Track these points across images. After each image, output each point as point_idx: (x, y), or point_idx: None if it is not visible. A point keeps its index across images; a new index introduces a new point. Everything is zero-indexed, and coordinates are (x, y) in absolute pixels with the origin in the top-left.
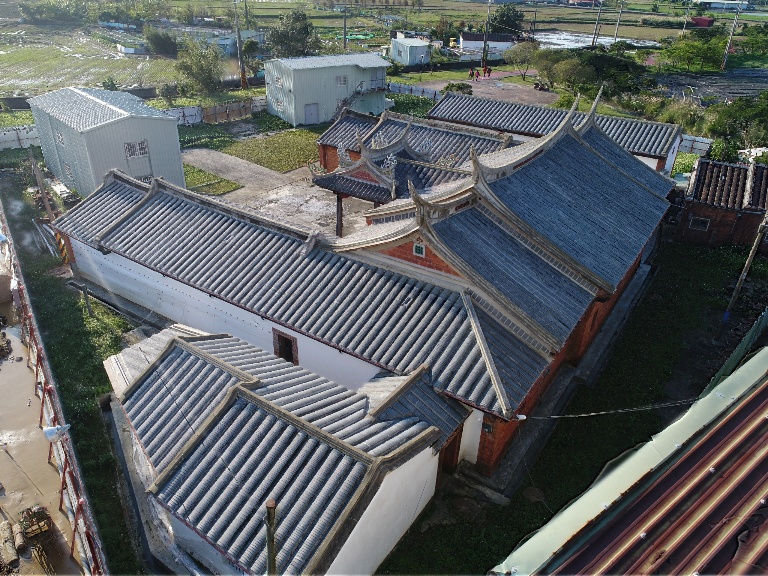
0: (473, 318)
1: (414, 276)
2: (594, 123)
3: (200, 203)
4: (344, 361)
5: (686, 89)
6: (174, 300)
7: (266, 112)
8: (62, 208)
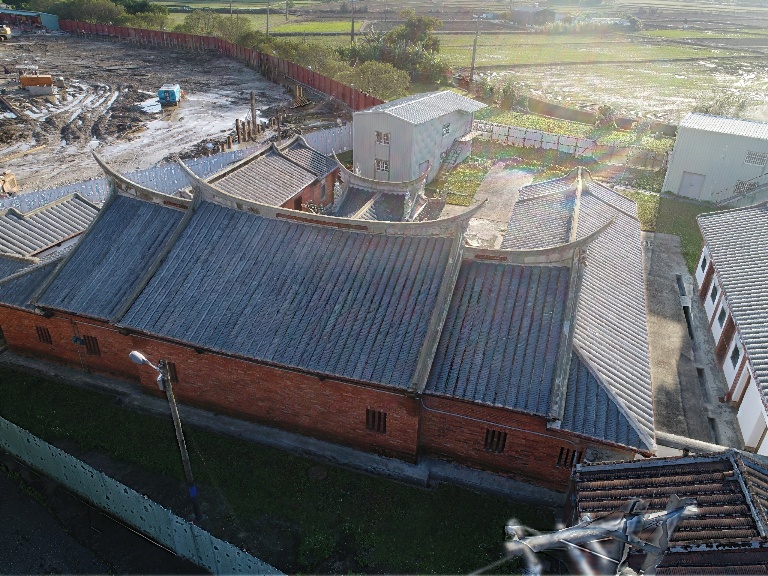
0: None
1: None
2: (573, 264)
3: None
4: None
5: None
6: None
7: None
8: None
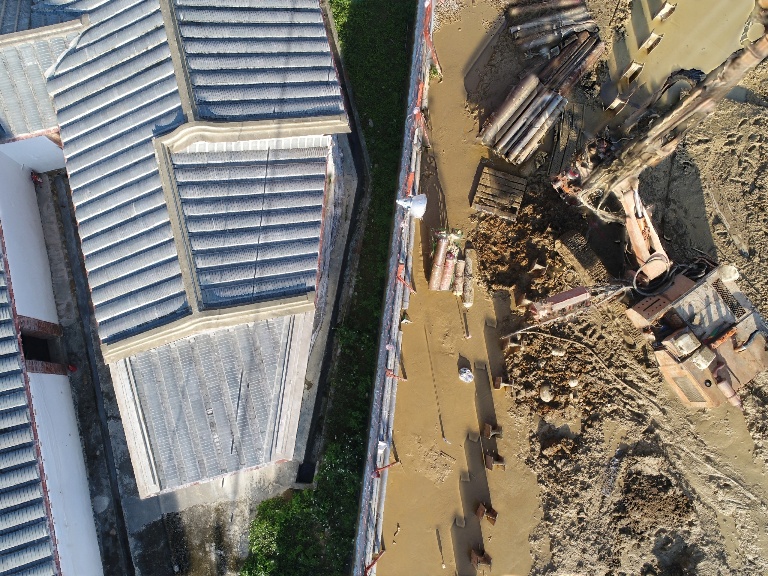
0: None
1: None
2: None
3: None
4: None
5: None
6: None
7: None
8: None
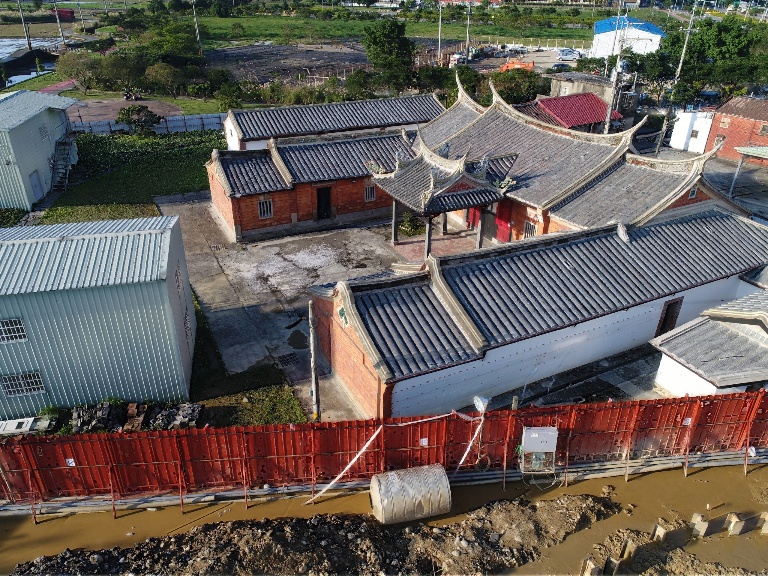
0: (741, 216)
1: None
2: None
3: (498, 255)
4: None
5: (302, 71)
6: (562, 350)
7: None
8: (102, 433)
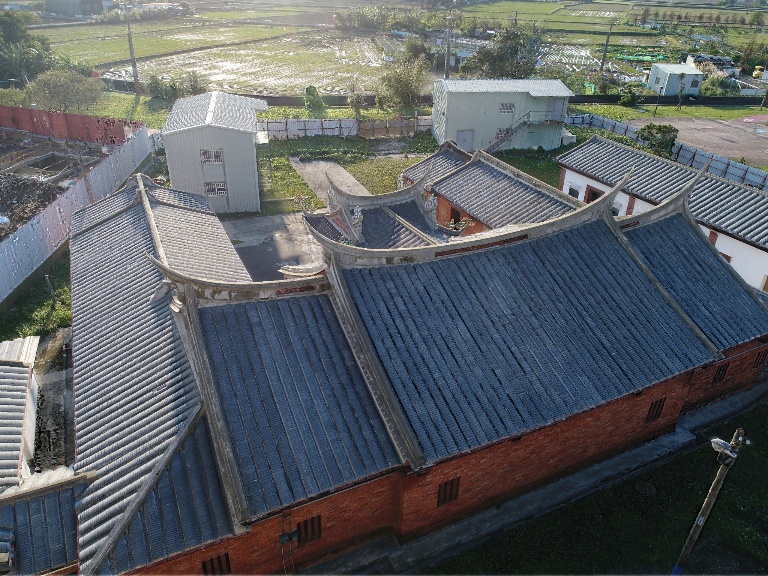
0: None
1: (189, 360)
2: (684, 209)
3: None
4: None
5: None
6: None
7: (431, 132)
8: None
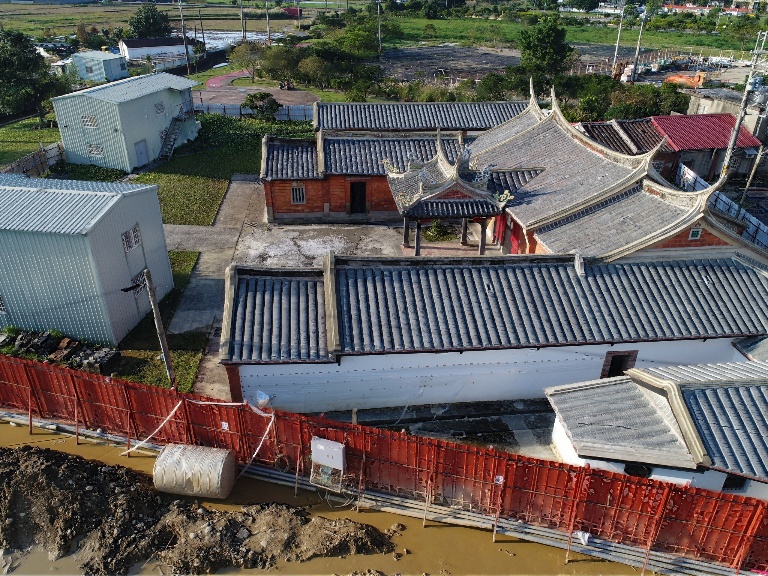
0: (766, 272)
1: (690, 258)
2: None
3: (410, 265)
4: (694, 349)
5: (438, 72)
6: (455, 378)
7: (63, 163)
8: (31, 356)
